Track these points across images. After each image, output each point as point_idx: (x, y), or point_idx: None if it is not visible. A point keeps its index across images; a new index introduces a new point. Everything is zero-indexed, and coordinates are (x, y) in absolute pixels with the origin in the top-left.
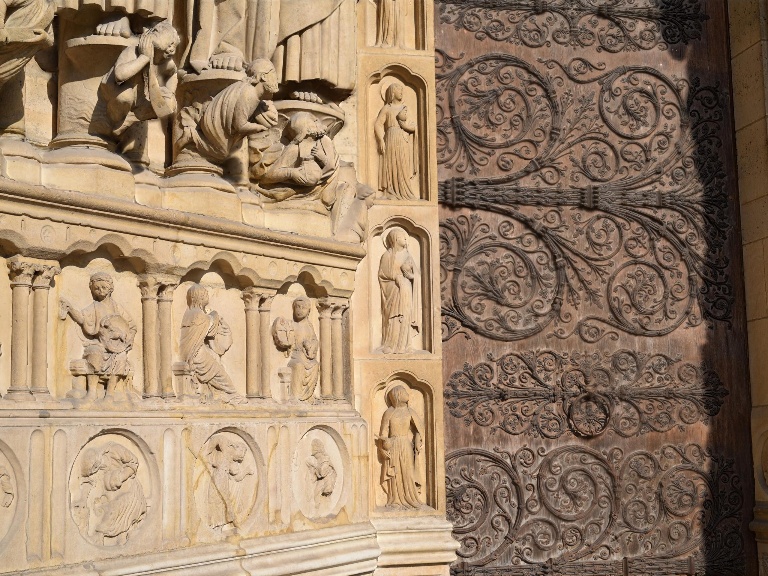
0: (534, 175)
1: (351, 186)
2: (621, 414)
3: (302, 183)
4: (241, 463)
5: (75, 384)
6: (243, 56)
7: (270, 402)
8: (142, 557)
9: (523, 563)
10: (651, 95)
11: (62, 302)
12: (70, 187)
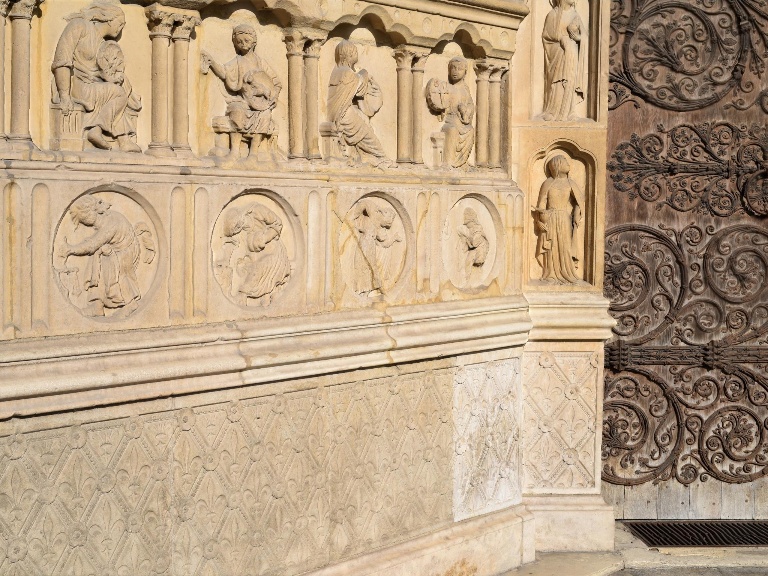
0: None
1: None
2: None
3: None
4: (389, 229)
5: (218, 142)
6: None
7: (421, 168)
8: (286, 319)
9: (683, 344)
10: None
11: (203, 55)
12: None
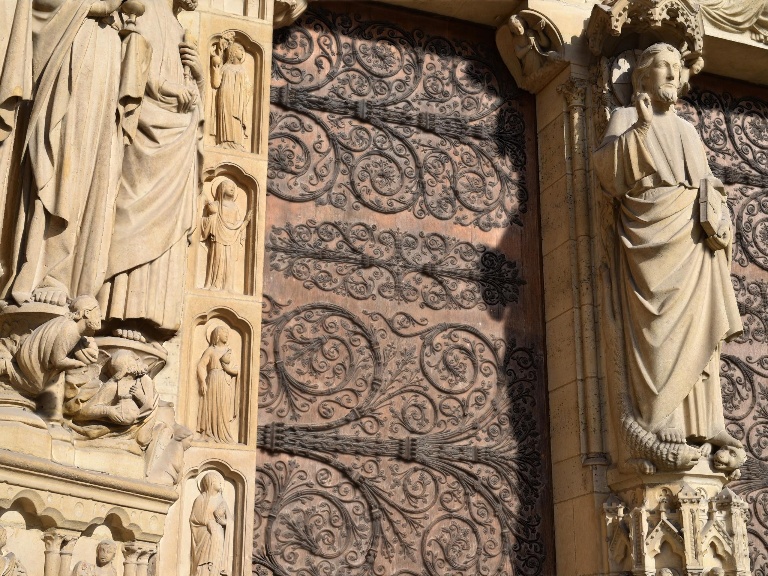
0: (354, 424)
1: (168, 427)
2: None
3: (118, 422)
4: None
5: None
6: (68, 291)
7: None
8: None
9: None
10: (470, 352)
11: None
12: None
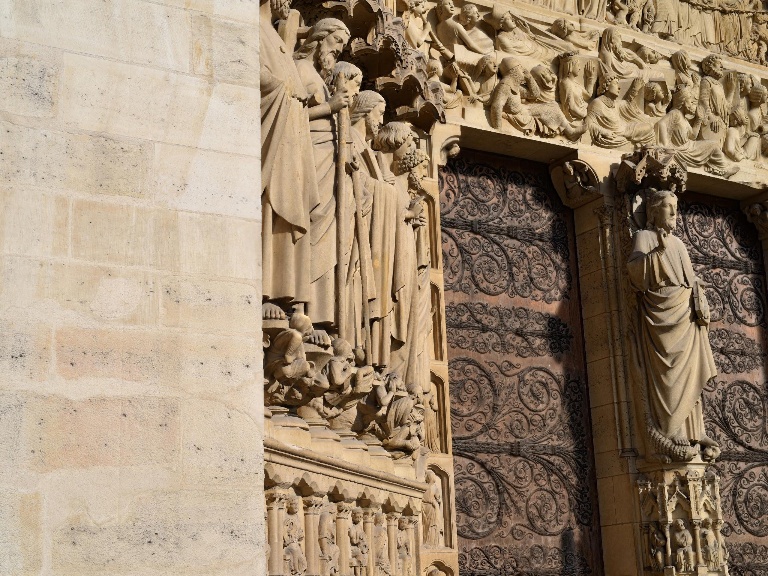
0: (485, 434)
1: None
2: None
3: (411, 449)
4: None
5: (352, 572)
6: None
7: None
8: None
9: None
10: (545, 385)
11: None
12: (351, 462)
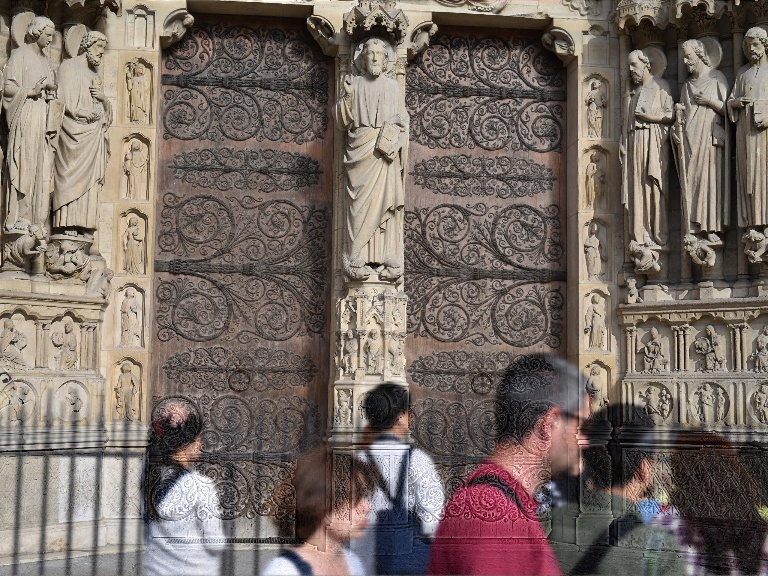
0: (219, 257)
1: (100, 270)
2: (258, 380)
3: (66, 273)
4: (27, 395)
5: None
6: (31, 222)
7: (46, 370)
8: None
9: (200, 452)
10: (287, 215)
11: None
12: None
